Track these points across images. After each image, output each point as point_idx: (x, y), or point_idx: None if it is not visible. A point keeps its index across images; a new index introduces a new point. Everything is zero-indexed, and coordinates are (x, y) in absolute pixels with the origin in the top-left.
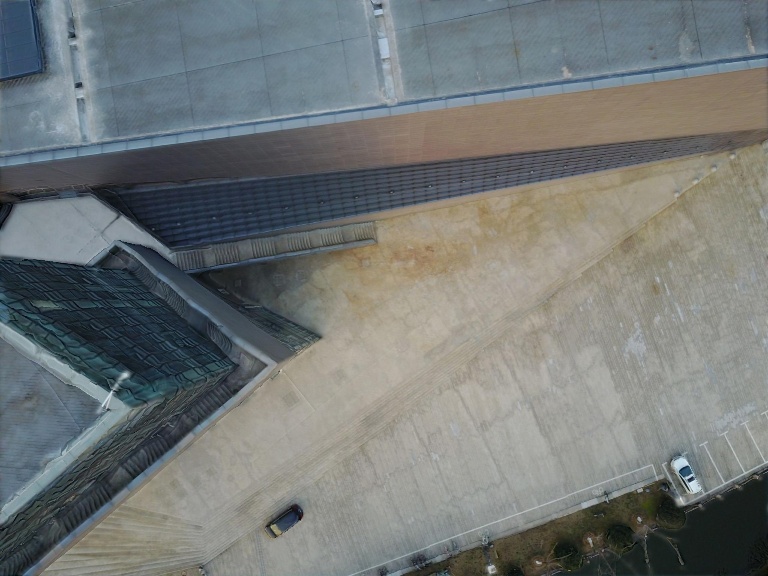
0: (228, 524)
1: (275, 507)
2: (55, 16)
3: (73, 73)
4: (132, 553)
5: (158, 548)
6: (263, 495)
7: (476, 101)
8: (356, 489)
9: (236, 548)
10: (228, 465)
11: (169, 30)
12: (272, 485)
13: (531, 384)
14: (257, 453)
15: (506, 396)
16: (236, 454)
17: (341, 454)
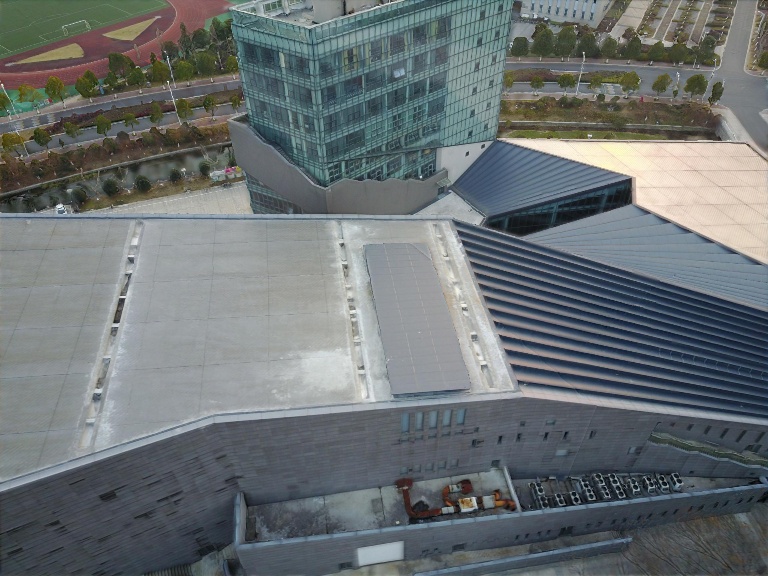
0: None
1: None
2: (356, 274)
3: (345, 250)
4: None
5: None
6: None
7: (89, 214)
8: None
9: None
10: None
11: (275, 261)
12: None
13: None
14: None
15: None
16: None
17: None
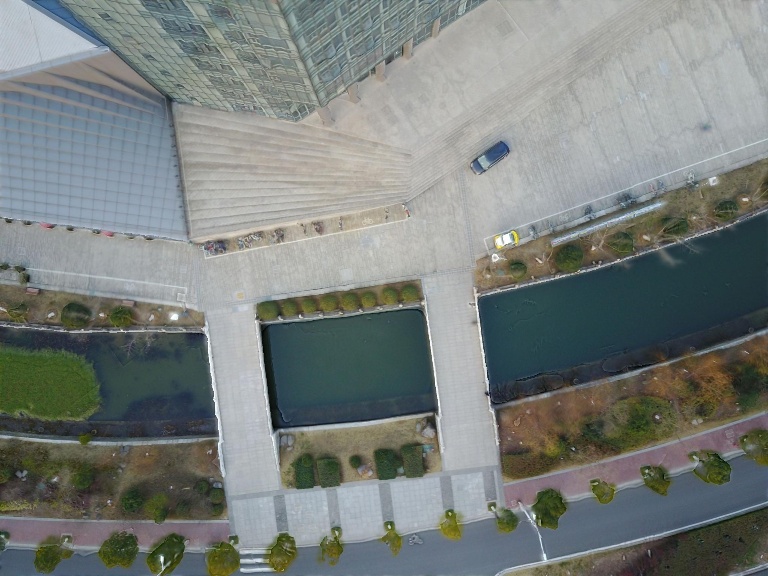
0: (435, 157)
1: (480, 144)
2: None
3: None
4: (338, 183)
5: (364, 179)
6: (472, 127)
7: None
8: (562, 128)
9: (439, 187)
10: (440, 92)
11: None
12: (482, 117)
13: (741, 24)
14: (469, 81)
15: (716, 36)
16: (448, 82)
17: (549, 91)
